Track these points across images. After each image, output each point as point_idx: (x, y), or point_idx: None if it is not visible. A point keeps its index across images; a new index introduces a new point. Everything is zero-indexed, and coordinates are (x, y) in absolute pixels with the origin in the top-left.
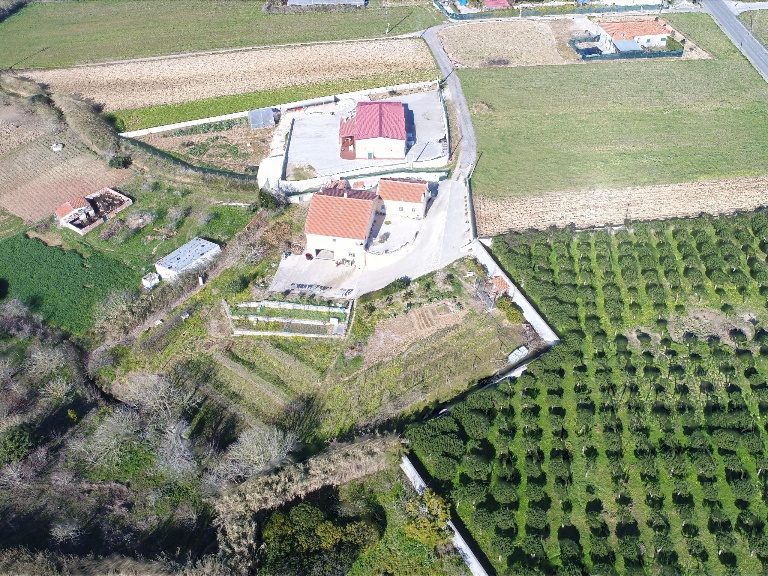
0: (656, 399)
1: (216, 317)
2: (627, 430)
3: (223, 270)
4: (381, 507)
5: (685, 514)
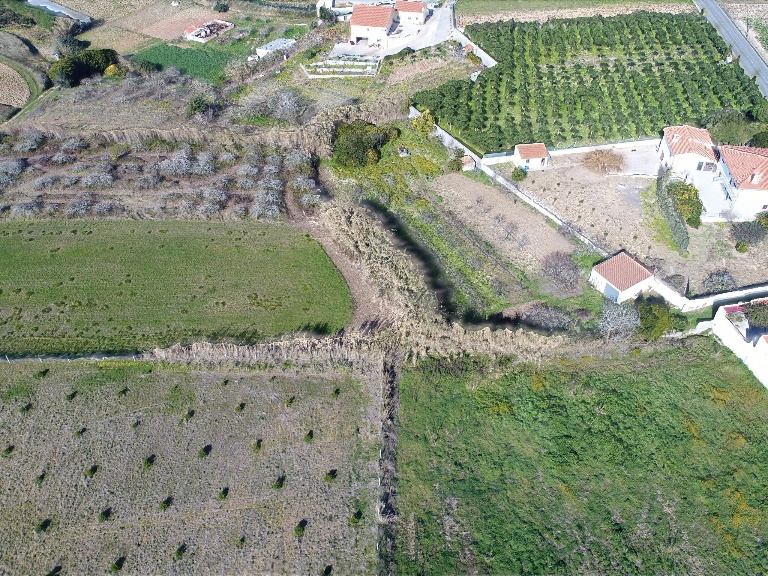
0: None
1: (297, 72)
2: (533, 96)
3: (299, 53)
4: (398, 129)
5: (554, 111)
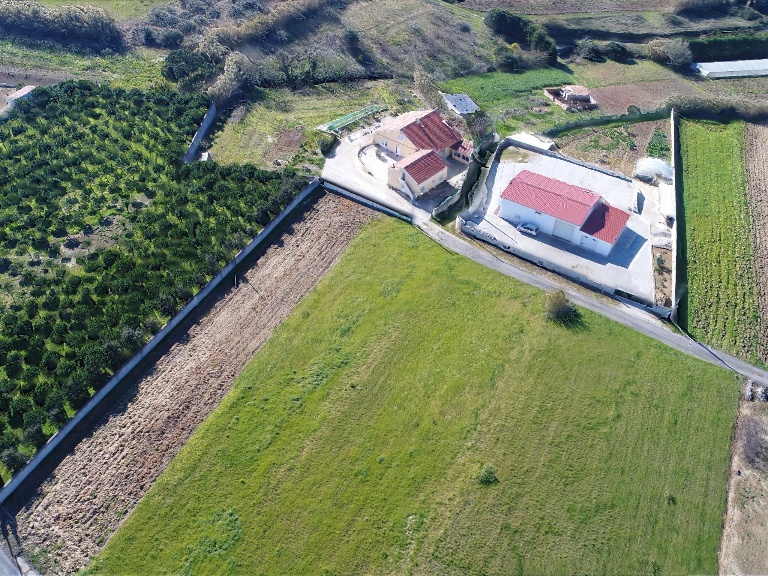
0: (100, 177)
1: None
2: None
3: None
4: None
5: None
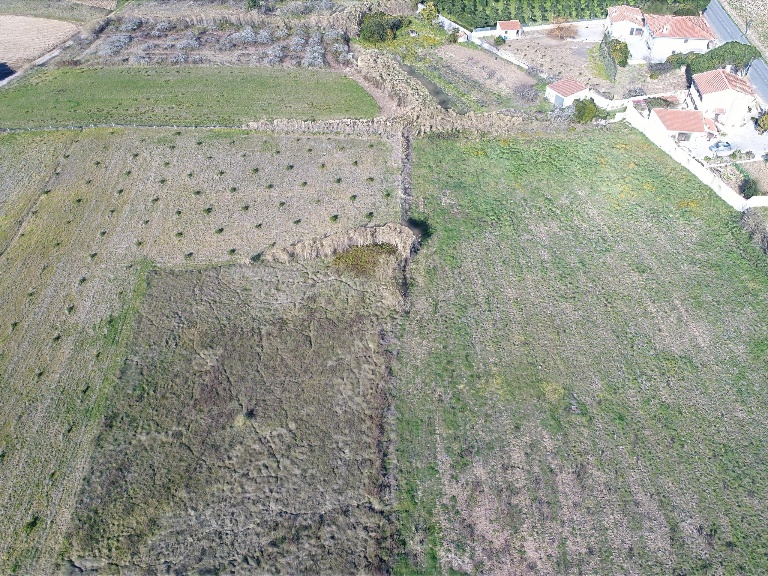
0: None
1: None
2: None
3: None
4: None
5: (528, 2)
